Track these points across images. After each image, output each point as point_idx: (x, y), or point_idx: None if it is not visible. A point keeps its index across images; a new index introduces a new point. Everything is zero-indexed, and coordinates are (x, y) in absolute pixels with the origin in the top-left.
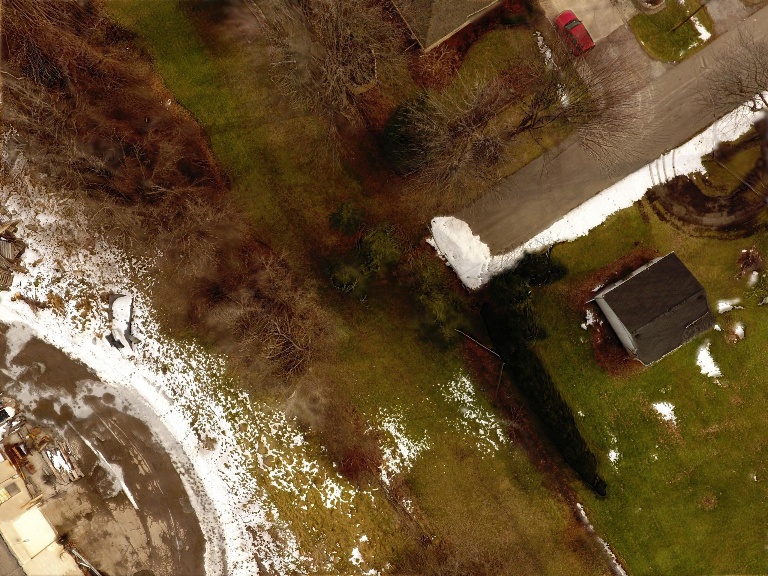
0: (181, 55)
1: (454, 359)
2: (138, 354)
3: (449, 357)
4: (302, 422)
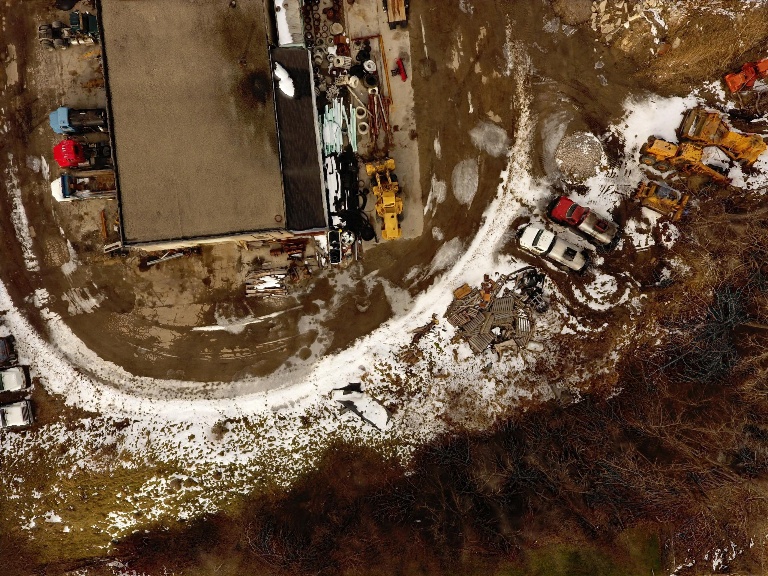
0: (569, 568)
1: None
2: (331, 404)
3: None
4: (199, 523)
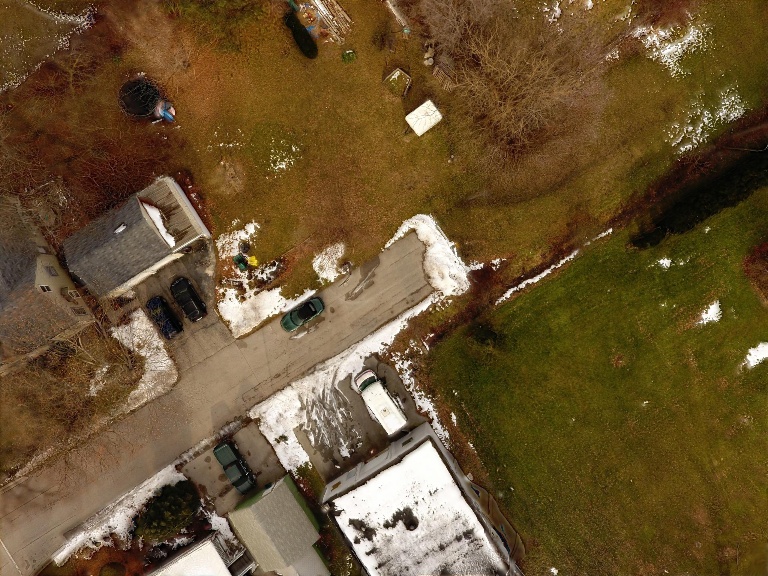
0: None
1: (762, 103)
2: None
3: (764, 98)
4: None
